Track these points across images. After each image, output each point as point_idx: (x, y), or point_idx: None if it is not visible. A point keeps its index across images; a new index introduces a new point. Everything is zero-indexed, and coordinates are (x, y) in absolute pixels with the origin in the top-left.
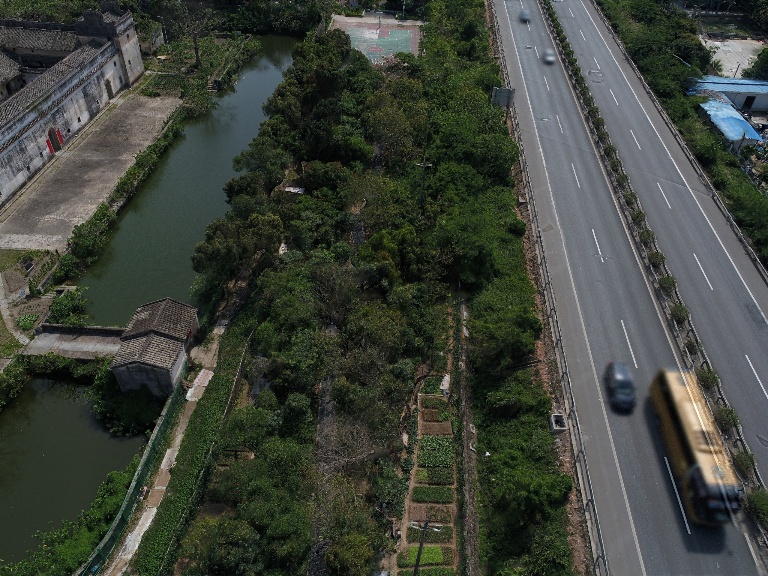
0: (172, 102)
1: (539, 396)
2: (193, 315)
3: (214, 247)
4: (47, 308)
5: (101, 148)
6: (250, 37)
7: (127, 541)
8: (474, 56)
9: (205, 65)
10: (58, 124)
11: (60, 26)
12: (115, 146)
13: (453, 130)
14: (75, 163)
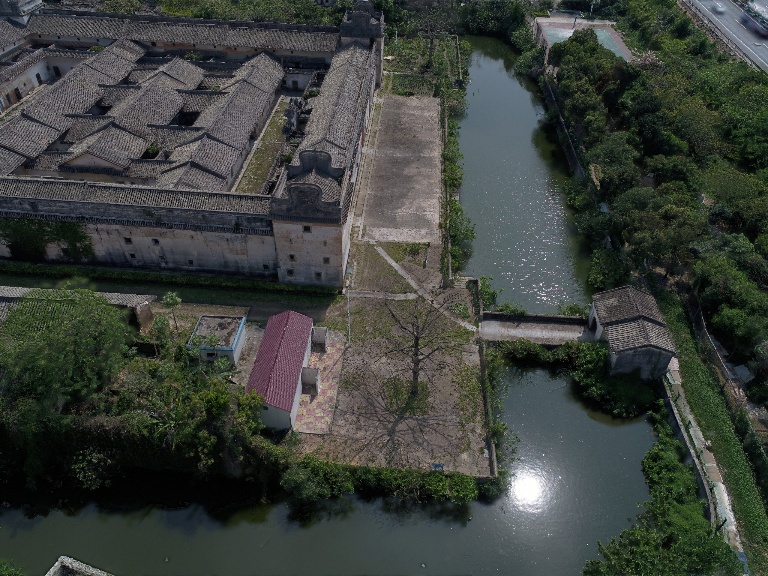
0: (430, 101)
1: None
2: (655, 302)
3: (659, 237)
4: (468, 297)
5: (398, 145)
6: None
7: (720, 514)
8: (705, 54)
9: (434, 65)
10: (364, 122)
11: (312, 28)
12: (409, 143)
13: None
14: (385, 160)
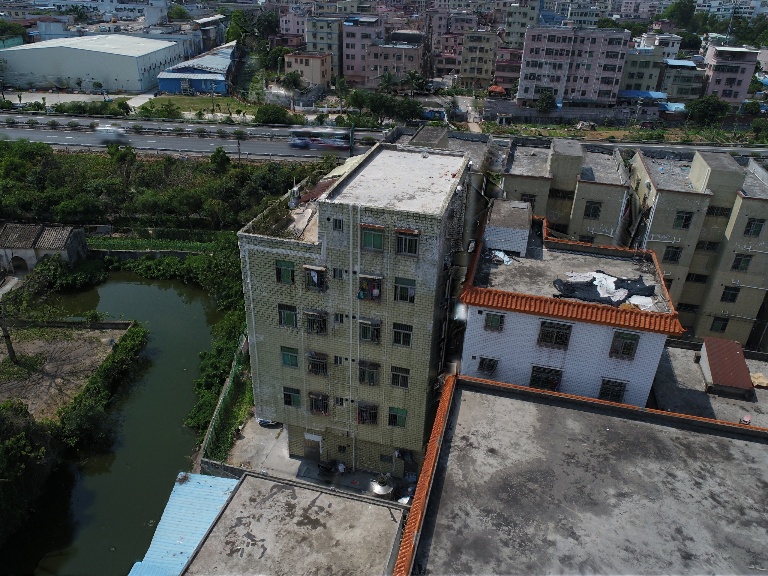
0: None
1: (163, 162)
2: None
3: None
4: None
5: None
6: None
7: None
8: None
9: None
10: None
11: None
12: None
13: None
14: None
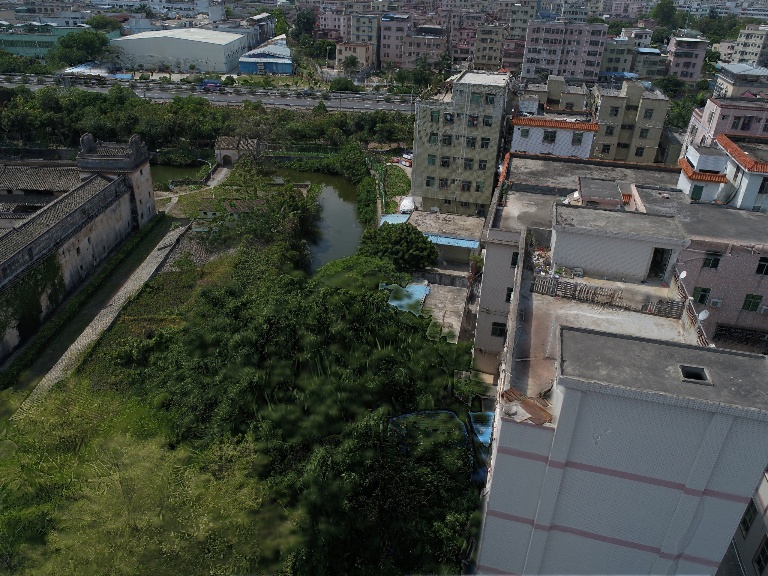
0: None
1: None
2: None
3: None
4: None
5: None
6: None
7: None
8: None
9: None
10: None
11: None
12: None
13: (96, 93)
14: None
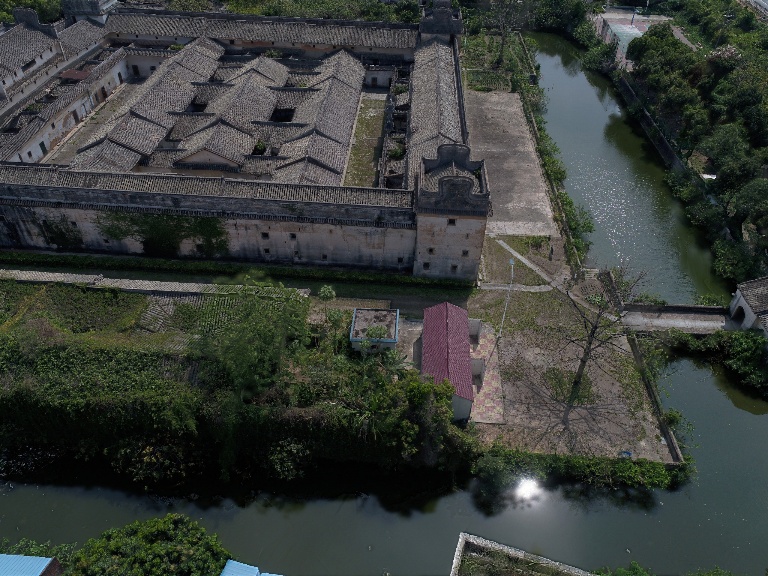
0: (509, 96)
1: None
2: None
3: None
4: (602, 289)
5: (490, 140)
6: (520, 34)
7: None
8: None
9: (504, 61)
10: None
11: (388, 25)
12: (501, 138)
13: None
14: (482, 155)
